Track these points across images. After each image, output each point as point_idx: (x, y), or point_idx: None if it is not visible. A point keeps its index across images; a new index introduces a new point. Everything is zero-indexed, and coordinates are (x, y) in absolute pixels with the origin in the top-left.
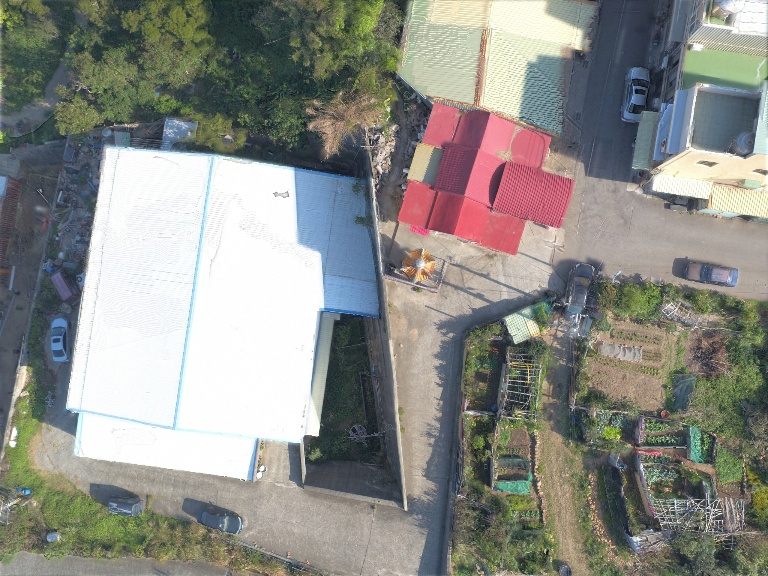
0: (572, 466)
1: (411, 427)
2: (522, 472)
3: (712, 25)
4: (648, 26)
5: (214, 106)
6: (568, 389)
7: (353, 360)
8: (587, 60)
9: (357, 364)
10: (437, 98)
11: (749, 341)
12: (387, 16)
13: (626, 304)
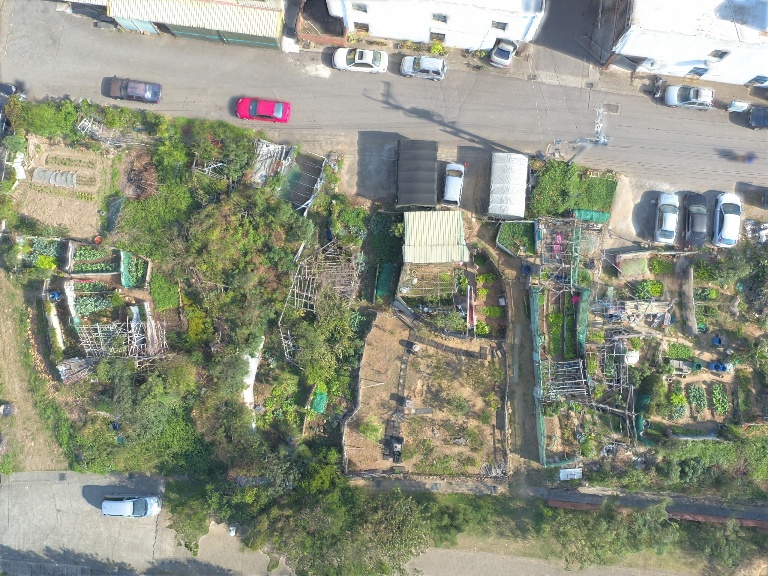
0: (14, 300)
1: None
2: None
3: None
4: None
5: None
6: None
7: None
8: None
9: None
10: None
11: (173, 158)
12: None
13: (32, 118)
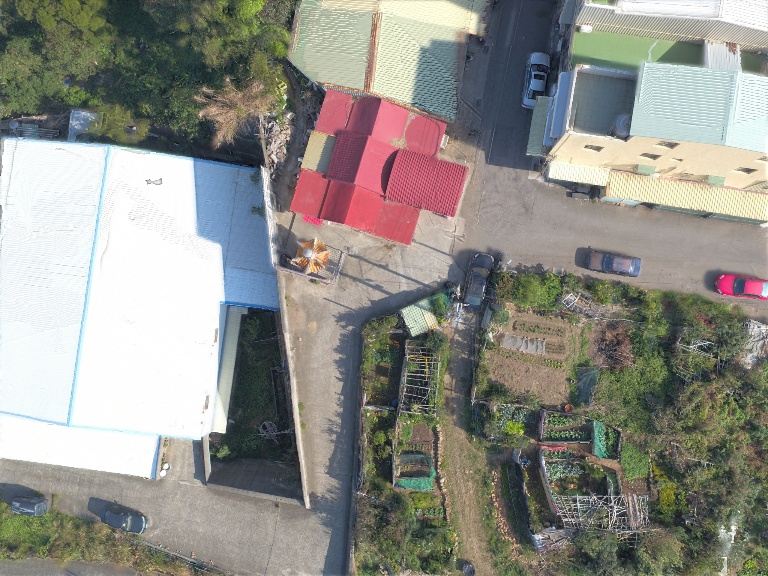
0: (475, 462)
1: (312, 423)
2: (425, 469)
3: (593, 5)
4: (549, 10)
5: (122, 97)
6: (470, 383)
7: (264, 355)
8: (487, 45)
9: (268, 359)
10: (328, 84)
11: (653, 332)
12: (275, 0)
13: (524, 295)
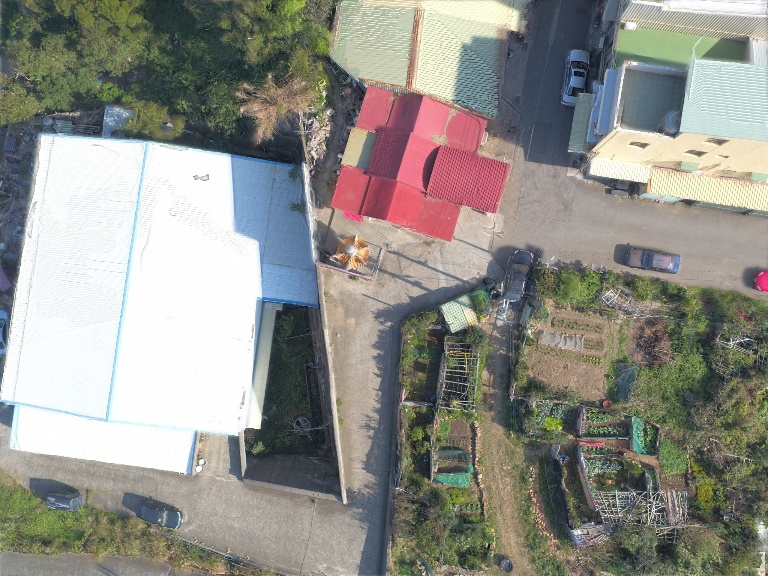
0: (513, 458)
1: (350, 419)
2: (463, 464)
3: (641, 2)
4: (589, 7)
5: (156, 93)
6: (509, 379)
7: (298, 352)
8: (526, 42)
9: (301, 356)
10: (369, 81)
11: (692, 329)
12: None
13: (564, 291)
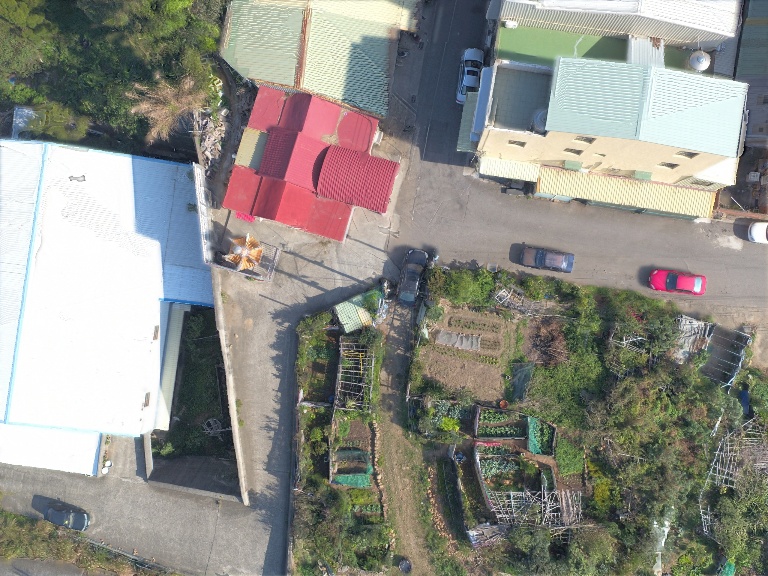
0: (412, 458)
1: (250, 420)
2: (362, 465)
3: None
4: (484, 6)
5: (66, 94)
6: (407, 379)
7: (209, 353)
8: (422, 42)
9: (212, 357)
10: (259, 81)
11: (586, 328)
12: None
13: (456, 291)
